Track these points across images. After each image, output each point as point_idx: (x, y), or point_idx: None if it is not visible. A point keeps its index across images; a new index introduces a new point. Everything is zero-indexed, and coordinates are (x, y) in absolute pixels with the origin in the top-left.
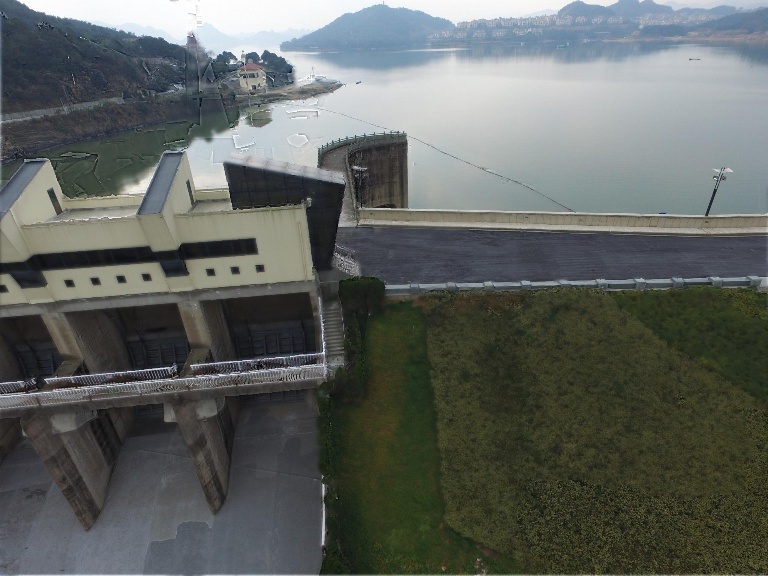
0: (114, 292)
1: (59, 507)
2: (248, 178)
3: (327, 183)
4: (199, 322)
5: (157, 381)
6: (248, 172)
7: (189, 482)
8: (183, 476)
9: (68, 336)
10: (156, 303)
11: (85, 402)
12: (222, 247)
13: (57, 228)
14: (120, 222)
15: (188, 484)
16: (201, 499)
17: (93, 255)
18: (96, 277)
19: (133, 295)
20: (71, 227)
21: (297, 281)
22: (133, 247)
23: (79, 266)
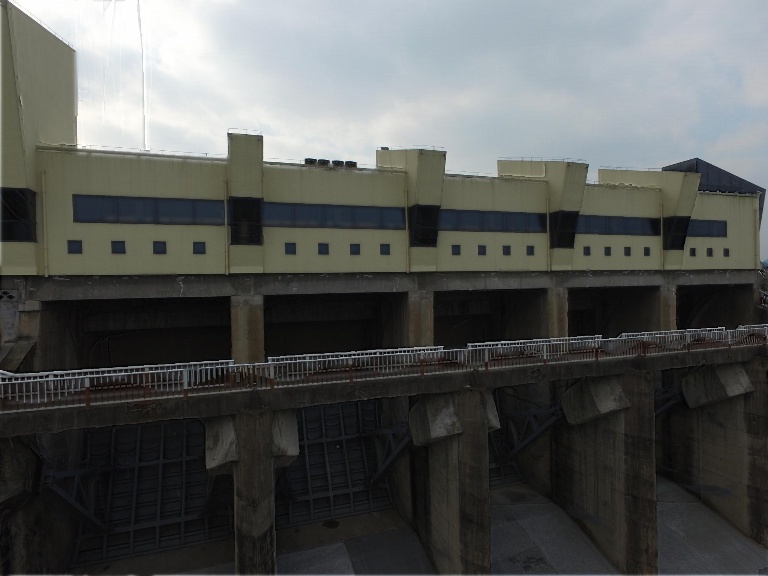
0: (617, 266)
1: (584, 574)
2: (708, 174)
3: (753, 187)
4: (672, 311)
5: (743, 329)
6: (708, 169)
7: (706, 526)
8: (690, 521)
9: (562, 320)
10: (644, 284)
11: (683, 354)
12: (702, 227)
13: (594, 189)
14: (640, 190)
15: (707, 528)
16: (744, 541)
17: (610, 222)
18: (609, 246)
19: (629, 272)
20: (604, 190)
21: (748, 270)
22: (643, 217)
23: (598, 233)
